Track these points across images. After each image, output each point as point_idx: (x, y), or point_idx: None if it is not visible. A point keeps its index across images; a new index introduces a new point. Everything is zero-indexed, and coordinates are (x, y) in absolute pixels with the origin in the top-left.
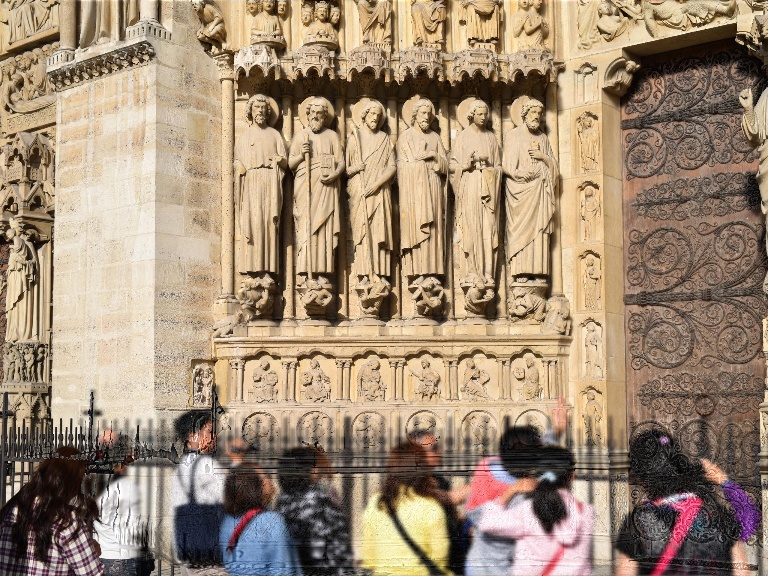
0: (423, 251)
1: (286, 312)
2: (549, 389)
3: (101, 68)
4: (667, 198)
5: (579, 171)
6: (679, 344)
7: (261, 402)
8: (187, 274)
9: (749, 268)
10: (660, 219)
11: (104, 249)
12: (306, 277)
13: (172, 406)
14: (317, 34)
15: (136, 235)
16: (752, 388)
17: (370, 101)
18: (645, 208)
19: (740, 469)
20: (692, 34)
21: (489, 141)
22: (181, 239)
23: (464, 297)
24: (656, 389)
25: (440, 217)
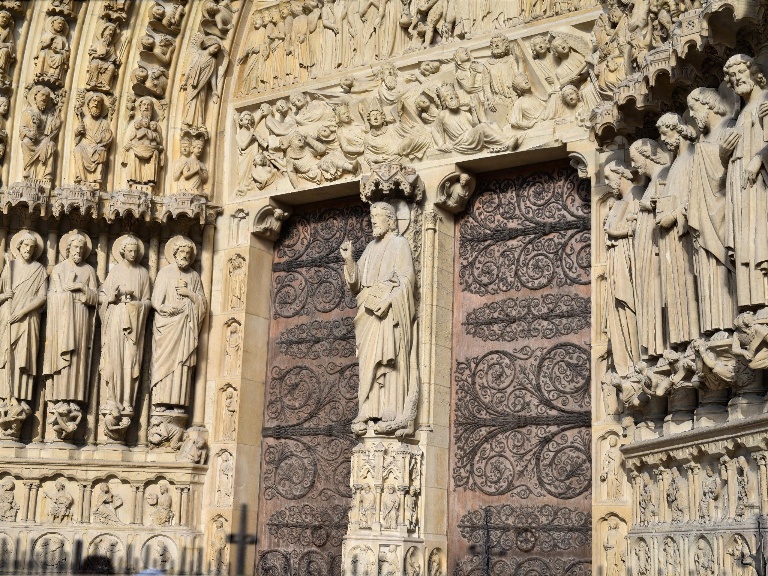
0: (63, 377)
1: None
2: (181, 515)
3: None
4: (304, 338)
5: (228, 308)
6: (304, 477)
7: None
8: None
9: None
10: (297, 357)
11: None
12: None
13: None
14: None
15: None
16: None
17: (26, 233)
18: (286, 346)
19: None
20: (326, 188)
21: (139, 276)
22: None
23: None
24: (282, 519)
25: (84, 346)
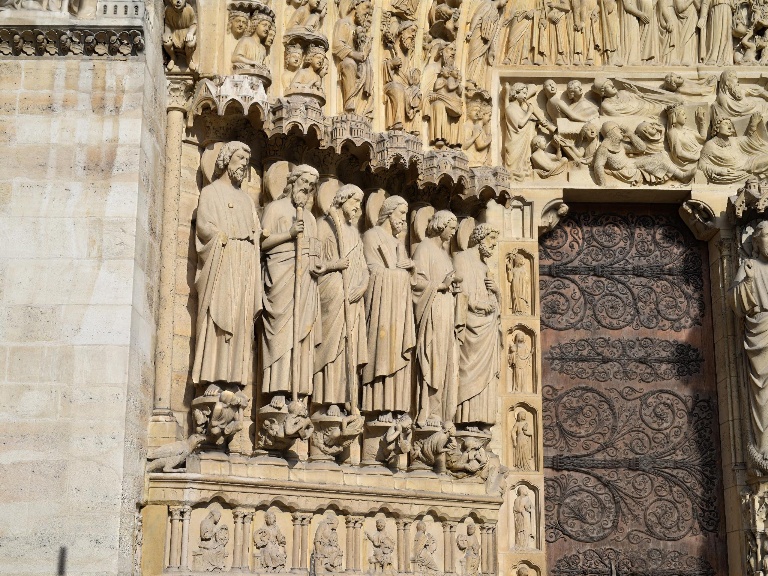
0: (399, 381)
1: (236, 443)
2: None
3: (23, 44)
4: (587, 355)
5: (506, 312)
6: (602, 516)
7: (212, 570)
8: (140, 373)
9: (680, 440)
10: (578, 377)
11: (8, 317)
12: (285, 398)
13: (125, 574)
14: (312, 85)
15: (87, 304)
16: (685, 567)
17: (350, 184)
18: (560, 363)
19: None
20: (639, 191)
21: (450, 261)
22: (140, 321)
23: None
24: (575, 565)
25: None
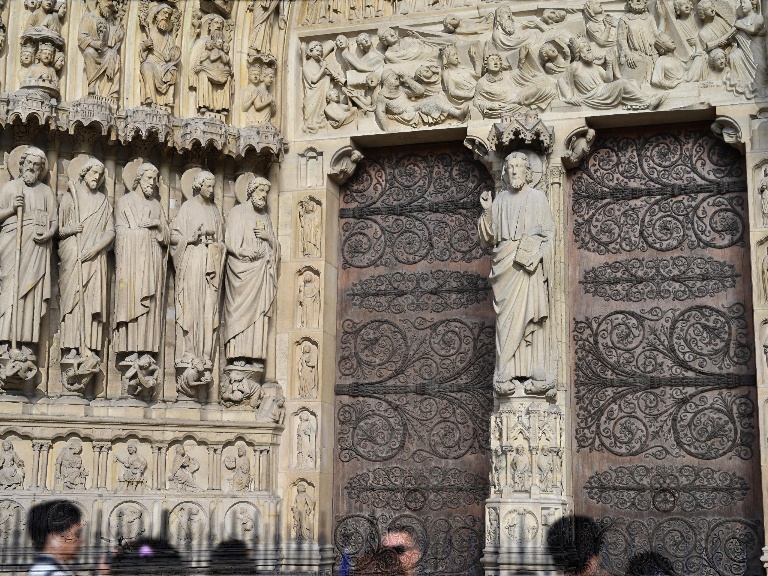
0: (141, 326)
1: None
2: (259, 480)
3: None
4: (384, 290)
5: (298, 255)
6: (391, 437)
7: None
8: None
9: (464, 365)
10: (376, 310)
11: None
12: (8, 346)
13: None
14: (39, 78)
15: None
16: (463, 483)
17: (91, 158)
18: (360, 298)
19: (449, 564)
20: (422, 132)
21: (214, 215)
22: None
23: (175, 378)
24: (365, 482)
25: (160, 290)
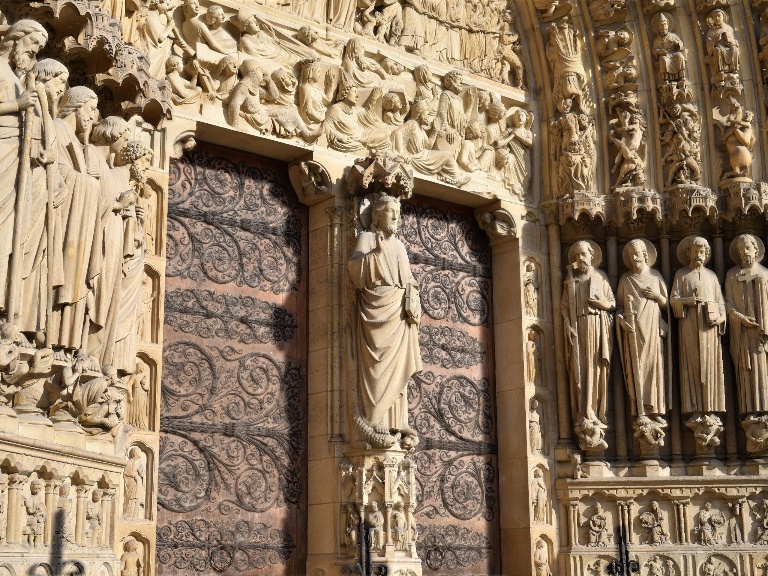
0: (79, 312)
1: None
2: None
3: None
4: (192, 308)
5: None
6: (197, 484)
7: None
8: None
9: (273, 407)
10: (182, 330)
11: None
12: None
13: None
14: None
15: None
16: (270, 540)
17: None
18: (165, 312)
19: None
20: (265, 140)
21: None
22: None
23: None
24: (166, 537)
25: None
